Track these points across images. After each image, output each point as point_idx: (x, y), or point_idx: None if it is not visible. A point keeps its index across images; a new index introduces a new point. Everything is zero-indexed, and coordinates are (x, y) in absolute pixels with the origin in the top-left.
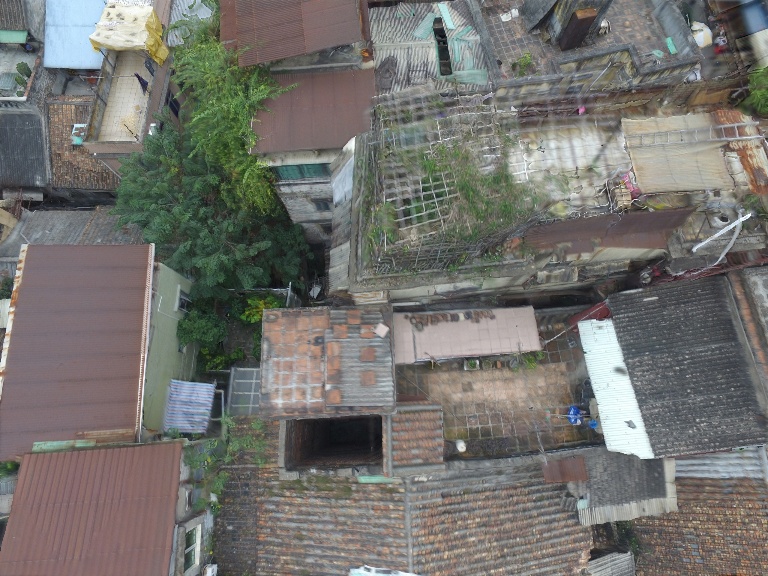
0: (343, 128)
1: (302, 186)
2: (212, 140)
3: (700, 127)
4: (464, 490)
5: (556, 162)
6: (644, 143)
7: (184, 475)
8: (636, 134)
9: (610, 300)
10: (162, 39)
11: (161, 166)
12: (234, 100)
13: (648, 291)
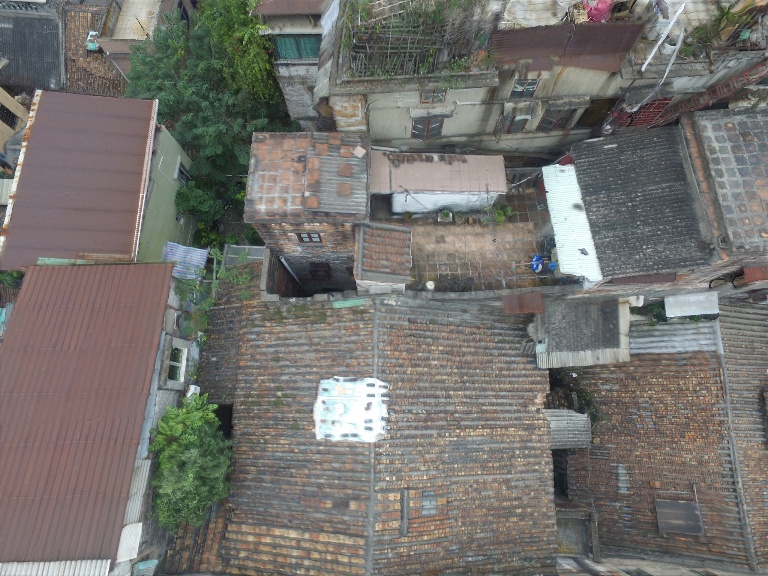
0: None
1: (299, 68)
2: (217, 20)
3: None
4: (430, 320)
5: None
6: None
7: (174, 304)
8: None
9: (573, 148)
10: None
11: (169, 50)
12: None
13: (608, 139)
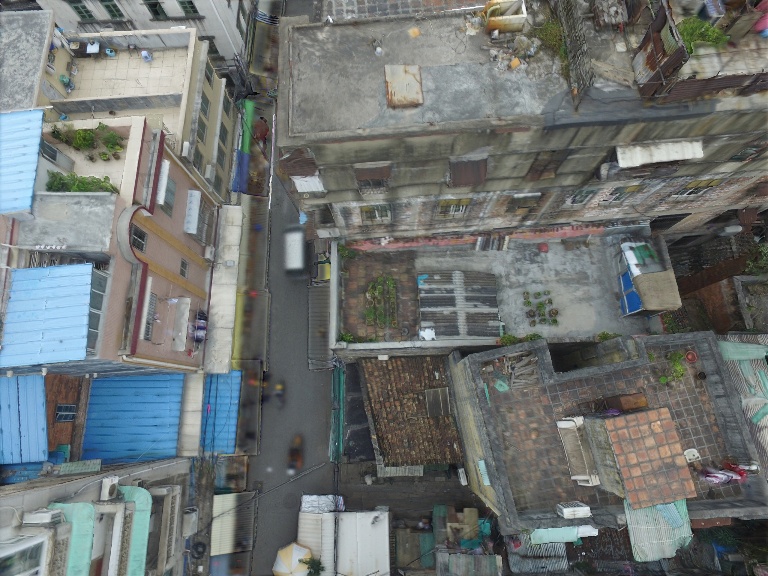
0: None
1: None
2: None
3: None
4: None
5: None
6: None
7: None
8: None
9: None
10: None
11: None
12: None
13: None
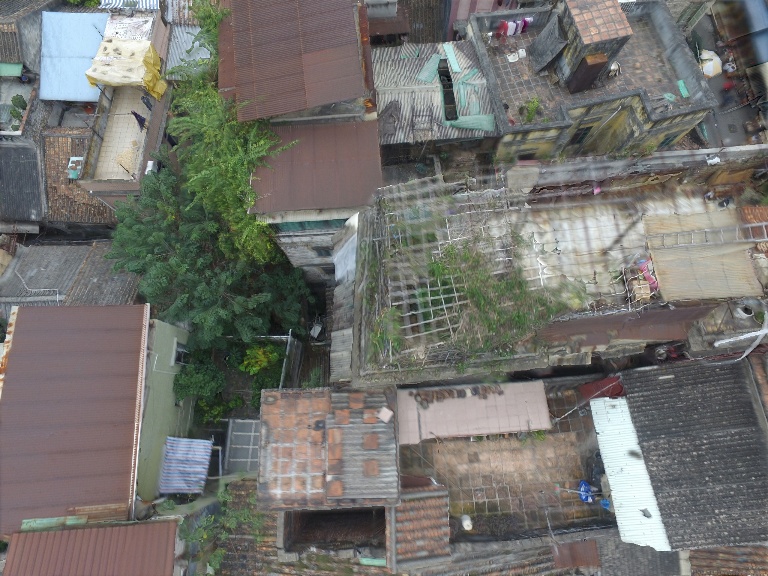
0: (345, 186)
1: (303, 237)
2: (210, 189)
3: (726, 226)
4: (470, 572)
5: (570, 244)
6: (666, 244)
7: (179, 550)
8: (658, 234)
9: (624, 377)
10: (160, 73)
11: (158, 213)
12: (232, 159)
13: (664, 369)
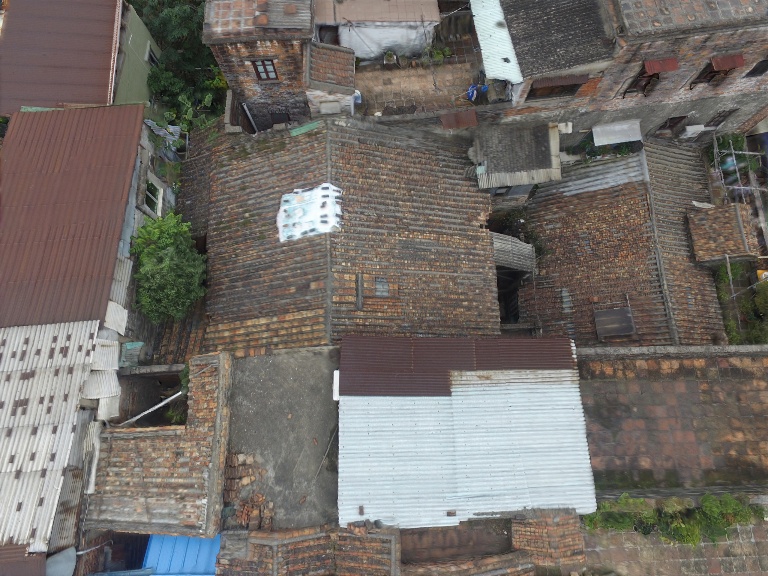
0: None
1: None
2: None
3: None
4: (378, 143)
5: None
6: None
7: None
8: None
9: None
10: None
11: None
12: None
13: None
